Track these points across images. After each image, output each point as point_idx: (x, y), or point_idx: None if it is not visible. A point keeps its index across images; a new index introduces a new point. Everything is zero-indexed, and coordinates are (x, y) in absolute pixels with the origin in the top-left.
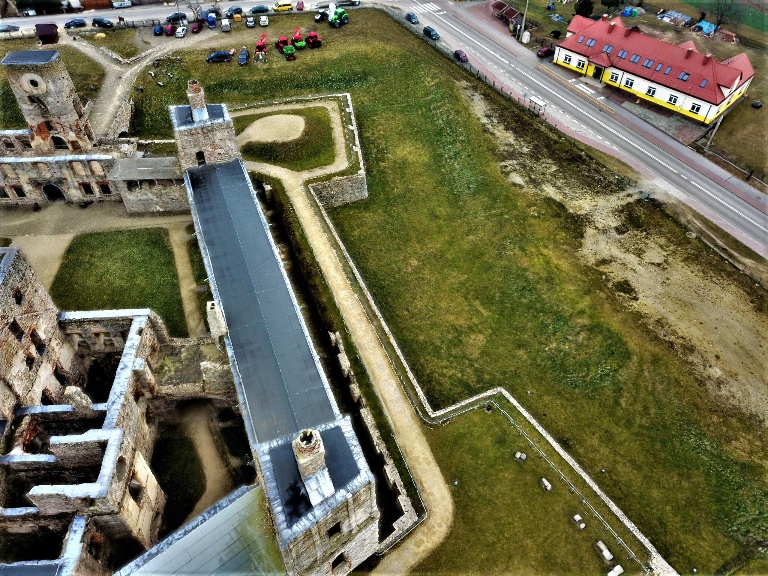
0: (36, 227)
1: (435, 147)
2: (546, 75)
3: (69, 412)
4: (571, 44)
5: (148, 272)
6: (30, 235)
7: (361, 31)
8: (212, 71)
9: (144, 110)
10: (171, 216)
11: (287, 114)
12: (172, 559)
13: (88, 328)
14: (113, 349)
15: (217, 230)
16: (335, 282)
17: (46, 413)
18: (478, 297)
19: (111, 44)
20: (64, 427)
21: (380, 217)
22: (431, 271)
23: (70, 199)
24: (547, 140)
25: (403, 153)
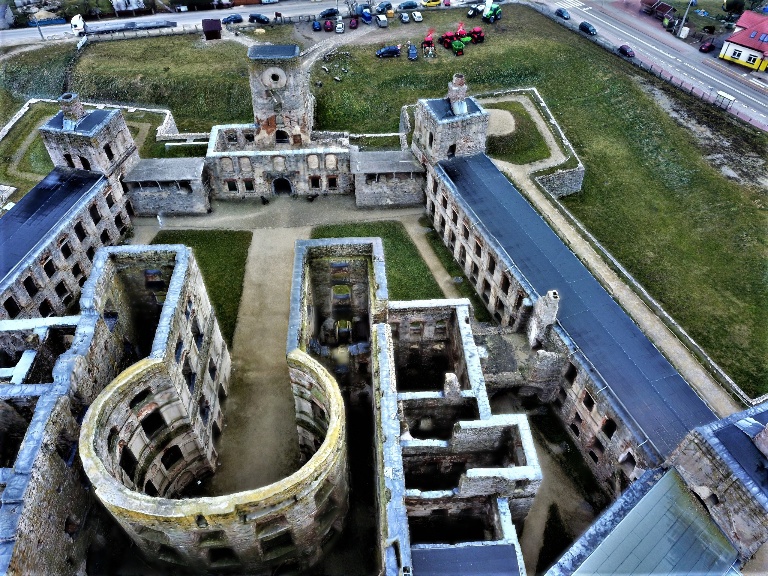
0: (271, 220)
1: (630, 141)
2: (716, 70)
3: (437, 399)
4: (743, 39)
5: (399, 264)
6: (268, 228)
7: (517, 26)
8: (385, 66)
9: (326, 105)
10: (400, 209)
11: (492, 108)
12: (623, 540)
13: (409, 317)
14: (418, 339)
15: (498, 222)
16: (602, 273)
17: (415, 400)
18: (728, 288)
19: (274, 39)
20: (423, 414)
21: (600, 210)
22: (671, 263)
23: (296, 192)
24: (744, 134)
25: (599, 147)
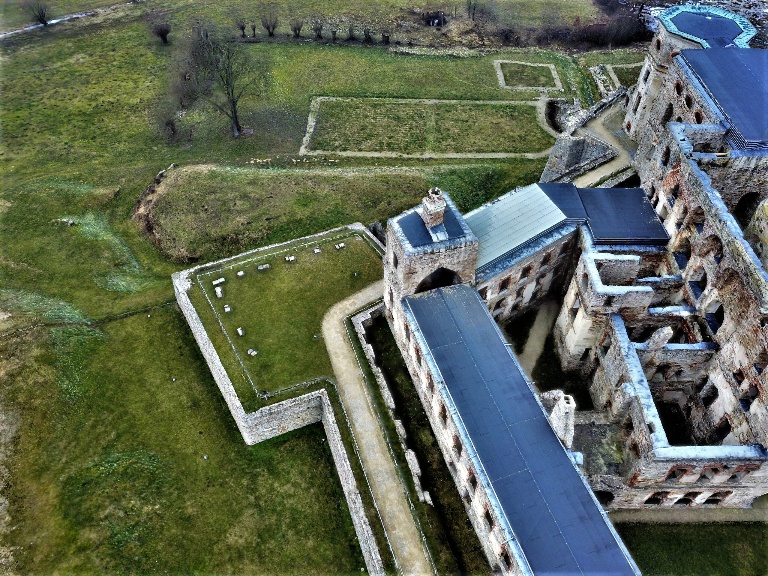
0: None
1: None
2: None
3: None
4: None
5: None
6: None
7: None
8: None
9: None
10: None
11: None
12: (521, 236)
13: None
14: None
15: None
16: None
17: None
18: None
19: None
20: None
21: None
22: None
23: None
24: None
25: None
